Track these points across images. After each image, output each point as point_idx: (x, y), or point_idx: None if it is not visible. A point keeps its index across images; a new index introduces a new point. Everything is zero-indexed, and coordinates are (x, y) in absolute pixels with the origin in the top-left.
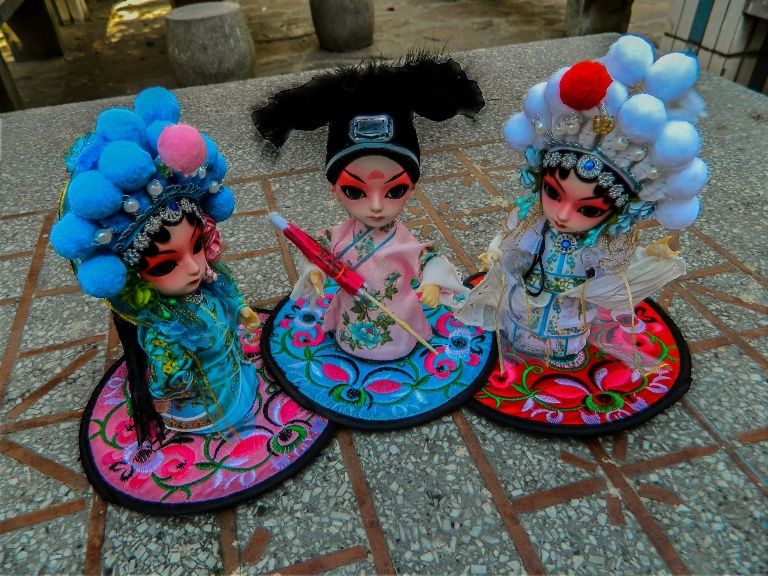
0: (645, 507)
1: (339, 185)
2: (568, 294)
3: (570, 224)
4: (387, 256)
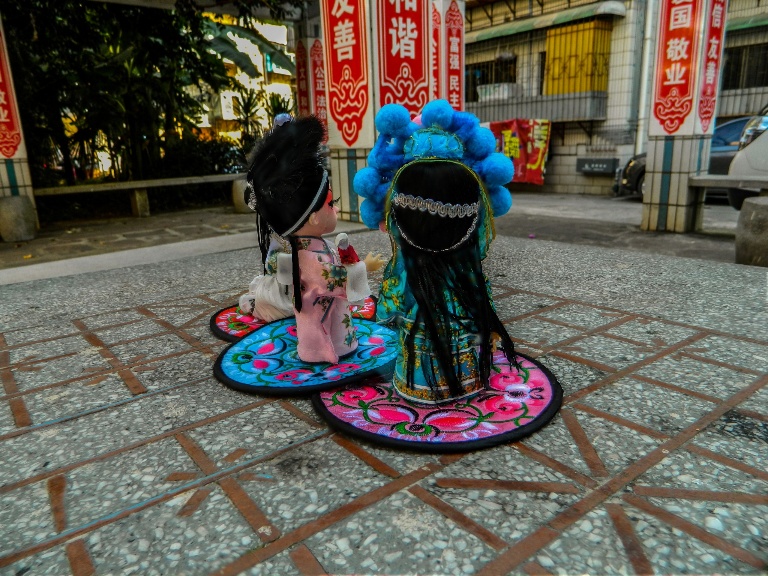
0: None
1: (327, 203)
2: None
3: None
4: None
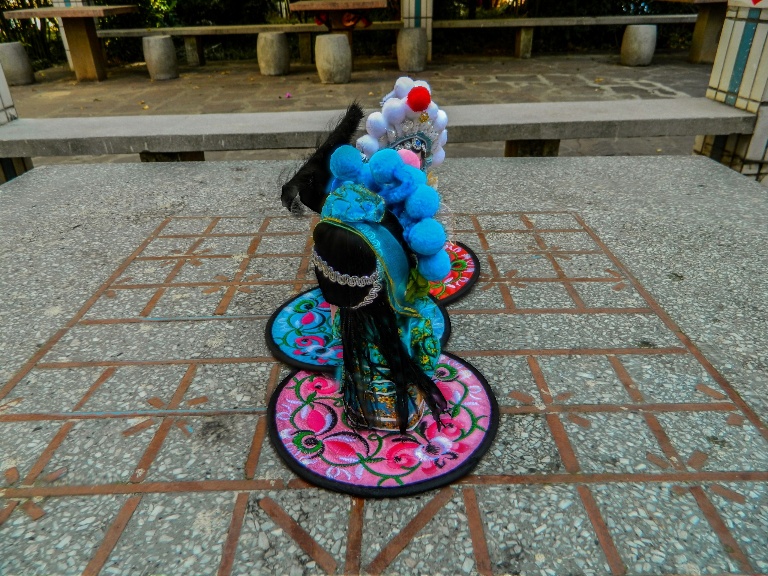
0: (518, 278)
1: None
2: None
3: None
4: None
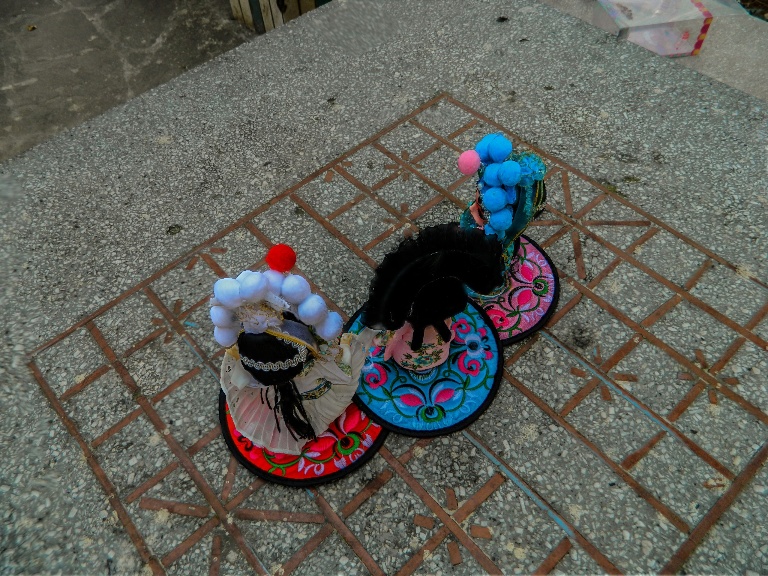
0: None
1: None
2: None
3: None
4: None
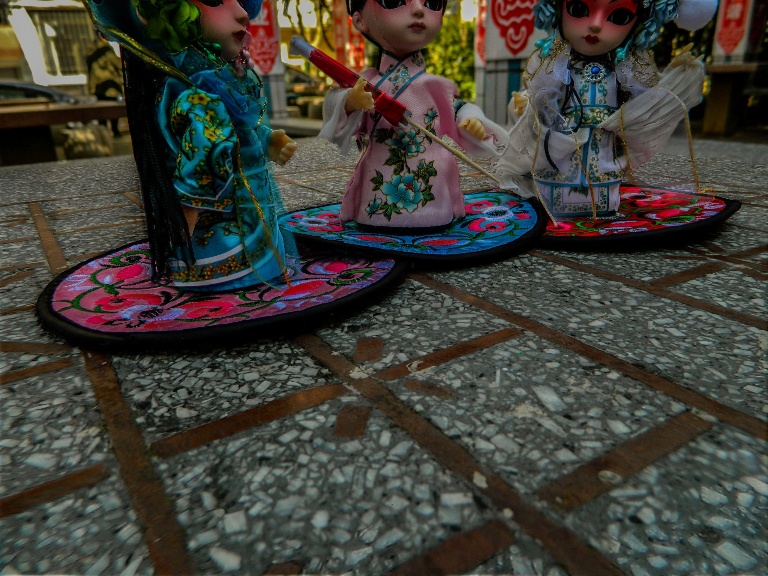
0: None
1: None
2: (606, 124)
3: (602, 35)
4: (426, 83)
